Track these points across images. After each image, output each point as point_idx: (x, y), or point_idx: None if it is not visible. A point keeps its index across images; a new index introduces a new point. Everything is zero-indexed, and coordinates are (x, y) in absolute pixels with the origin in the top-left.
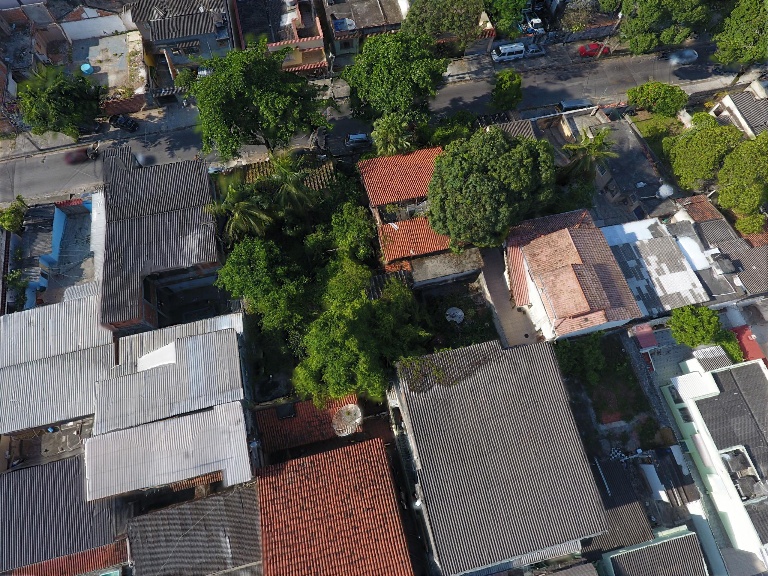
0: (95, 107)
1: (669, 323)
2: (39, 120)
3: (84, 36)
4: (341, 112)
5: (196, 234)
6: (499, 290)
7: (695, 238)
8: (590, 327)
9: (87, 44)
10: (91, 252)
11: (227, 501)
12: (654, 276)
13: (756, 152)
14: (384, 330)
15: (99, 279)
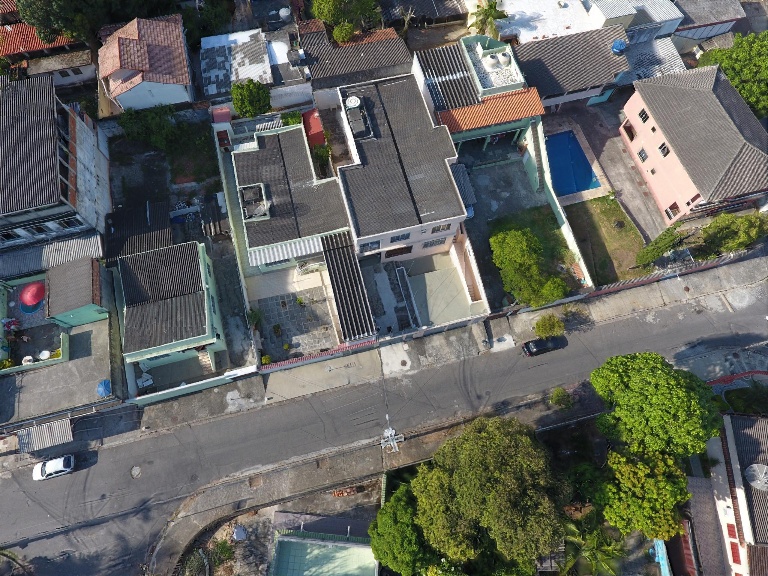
0: None
1: None
2: None
3: None
4: None
5: None
6: None
7: (287, 42)
8: (137, 90)
9: None
10: None
11: None
12: (234, 67)
13: None
14: None
15: None
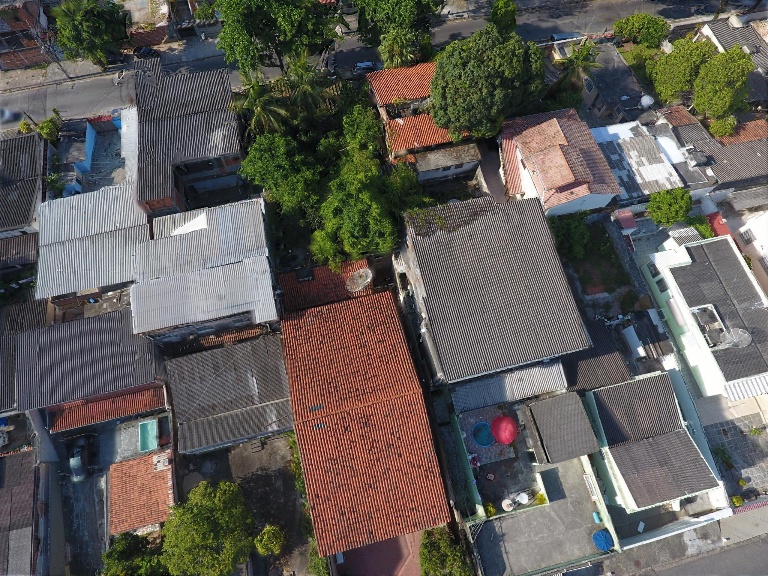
0: (124, 30)
1: (648, 208)
2: (71, 44)
3: None
4: (348, 45)
5: (221, 131)
6: (495, 187)
7: (672, 138)
8: (575, 200)
9: None
10: (122, 158)
11: (254, 347)
12: (634, 167)
13: (727, 59)
14: (392, 195)
15: (132, 174)
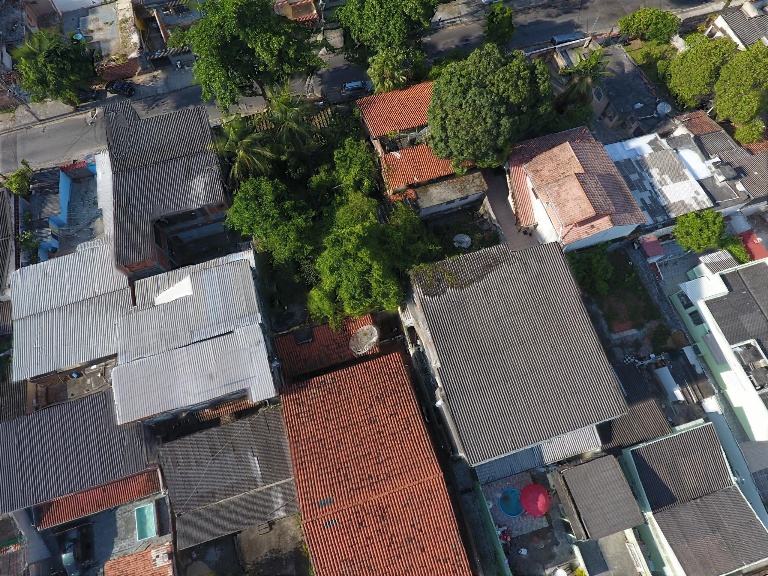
0: (91, 68)
1: (674, 231)
2: (37, 87)
3: (73, 7)
4: (335, 63)
5: (202, 178)
6: (504, 216)
7: (695, 150)
8: (597, 234)
9: (77, 15)
10: (99, 210)
11: (253, 423)
12: (657, 187)
13: (751, 59)
14: (394, 246)
15: (110, 230)
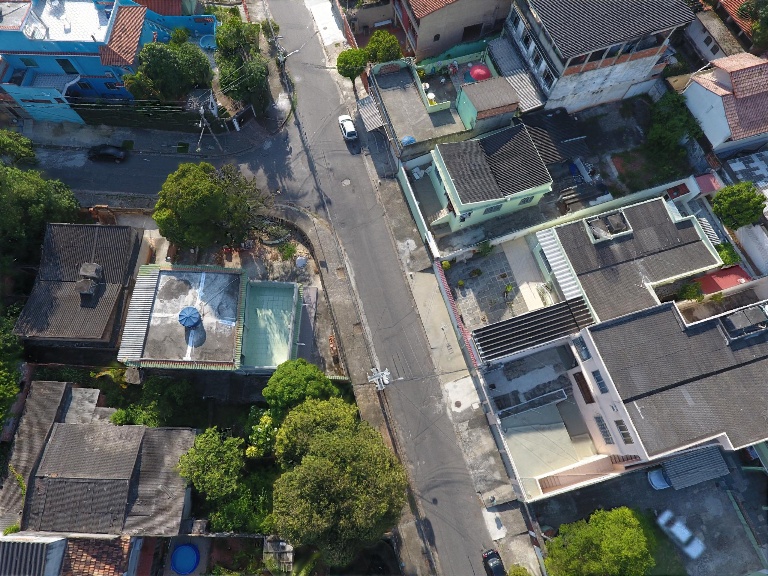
0: None
1: None
2: None
3: None
4: None
5: None
6: None
7: None
8: (709, 96)
9: None
10: None
11: None
12: None
13: None
14: None
15: None
